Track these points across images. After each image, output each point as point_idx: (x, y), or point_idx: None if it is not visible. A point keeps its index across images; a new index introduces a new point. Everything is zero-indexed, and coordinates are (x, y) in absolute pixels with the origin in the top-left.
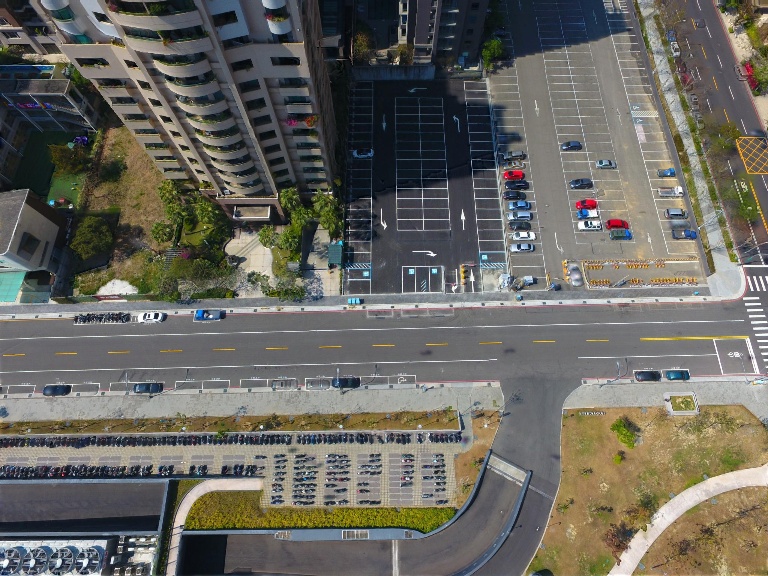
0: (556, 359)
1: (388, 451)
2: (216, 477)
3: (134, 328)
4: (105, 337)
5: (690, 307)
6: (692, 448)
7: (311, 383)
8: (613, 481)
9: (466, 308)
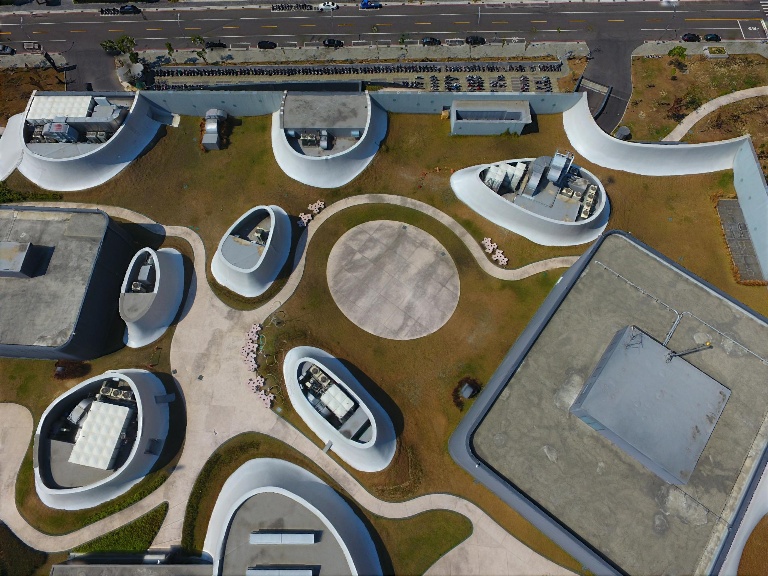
0: (625, 30)
1: (510, 76)
2: (393, 83)
3: (316, 13)
4: (296, 18)
5: (720, 3)
6: (724, 75)
7: (450, 42)
8: (669, 90)
9: (558, 3)
